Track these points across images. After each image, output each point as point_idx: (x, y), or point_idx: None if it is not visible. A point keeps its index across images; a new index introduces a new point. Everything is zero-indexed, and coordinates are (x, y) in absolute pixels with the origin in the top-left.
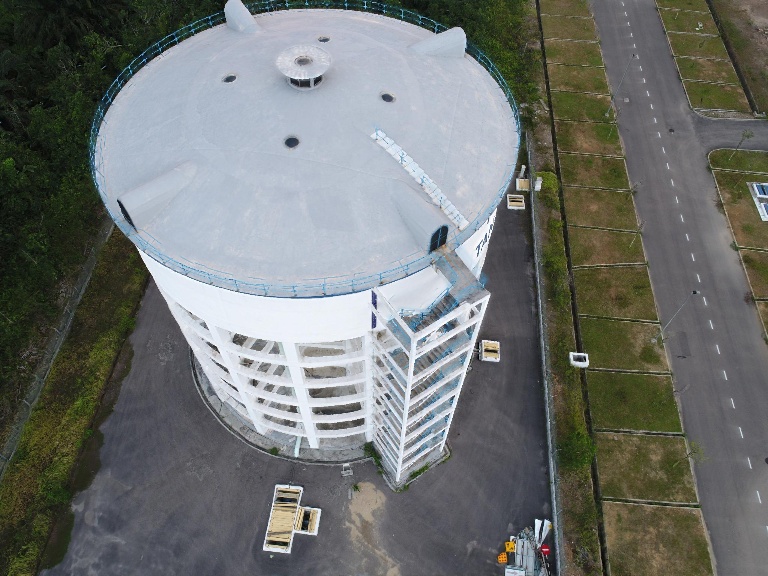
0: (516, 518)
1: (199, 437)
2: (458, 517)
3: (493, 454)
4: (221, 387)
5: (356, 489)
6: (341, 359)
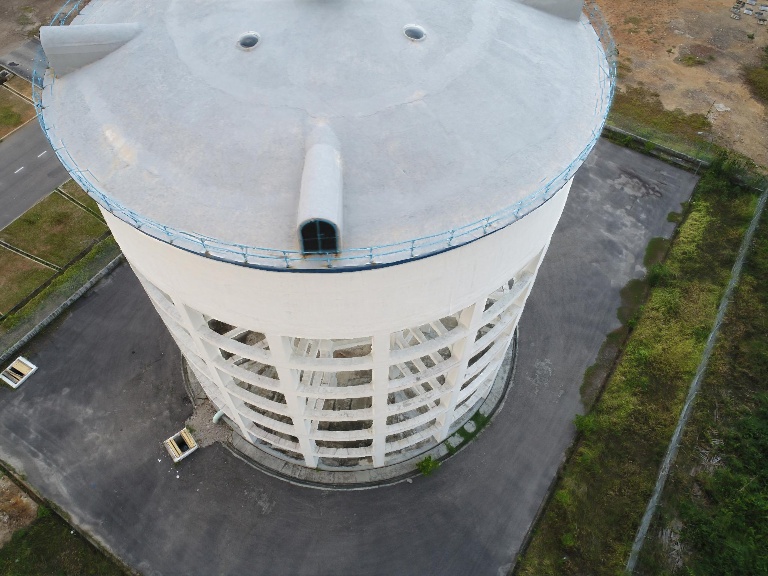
0: None
1: None
2: None
3: None
4: None
5: None
6: None
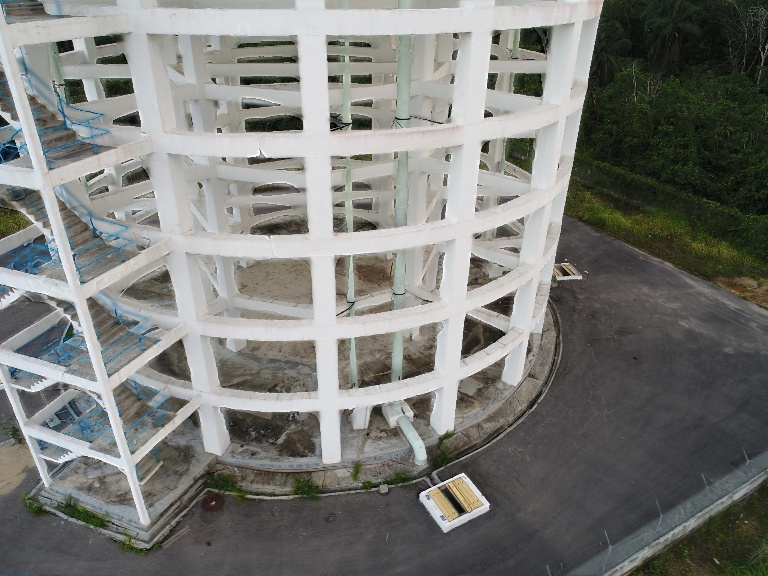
0: None
1: None
2: None
3: None
4: None
5: (16, 439)
6: None
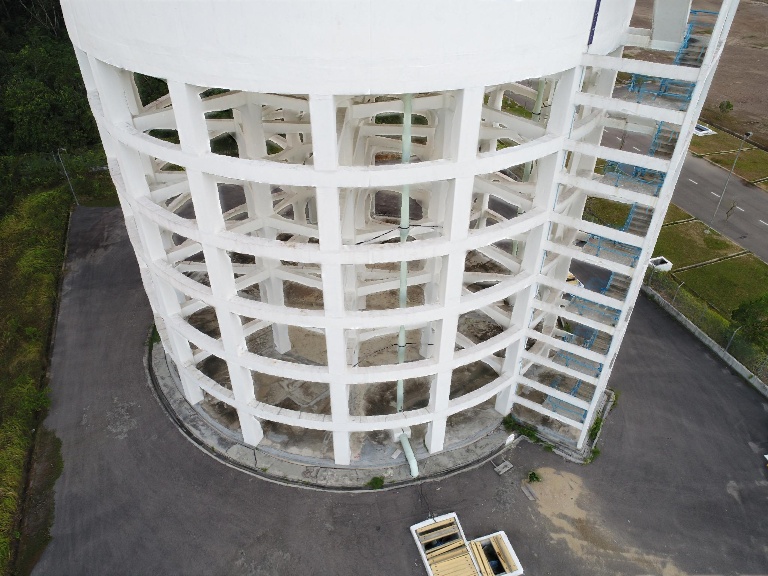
0: (750, 433)
1: (238, 514)
2: (686, 461)
3: (660, 376)
4: (277, 370)
5: (534, 480)
6: (533, 145)
